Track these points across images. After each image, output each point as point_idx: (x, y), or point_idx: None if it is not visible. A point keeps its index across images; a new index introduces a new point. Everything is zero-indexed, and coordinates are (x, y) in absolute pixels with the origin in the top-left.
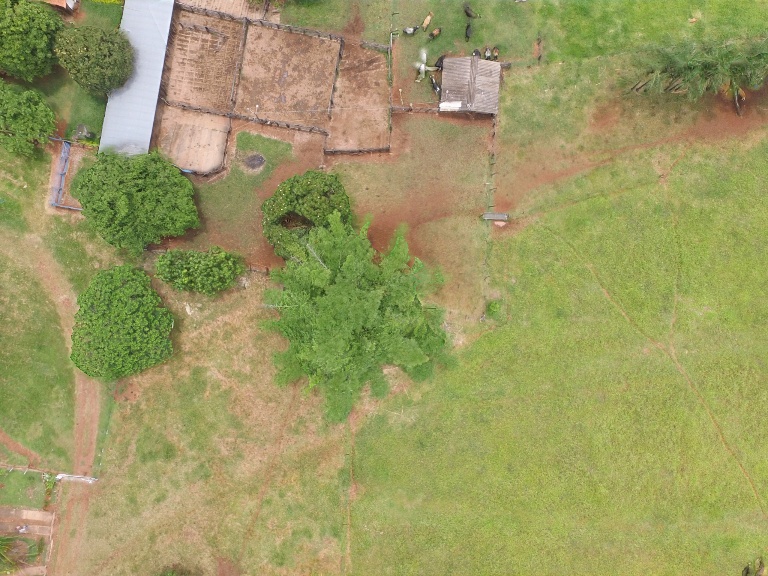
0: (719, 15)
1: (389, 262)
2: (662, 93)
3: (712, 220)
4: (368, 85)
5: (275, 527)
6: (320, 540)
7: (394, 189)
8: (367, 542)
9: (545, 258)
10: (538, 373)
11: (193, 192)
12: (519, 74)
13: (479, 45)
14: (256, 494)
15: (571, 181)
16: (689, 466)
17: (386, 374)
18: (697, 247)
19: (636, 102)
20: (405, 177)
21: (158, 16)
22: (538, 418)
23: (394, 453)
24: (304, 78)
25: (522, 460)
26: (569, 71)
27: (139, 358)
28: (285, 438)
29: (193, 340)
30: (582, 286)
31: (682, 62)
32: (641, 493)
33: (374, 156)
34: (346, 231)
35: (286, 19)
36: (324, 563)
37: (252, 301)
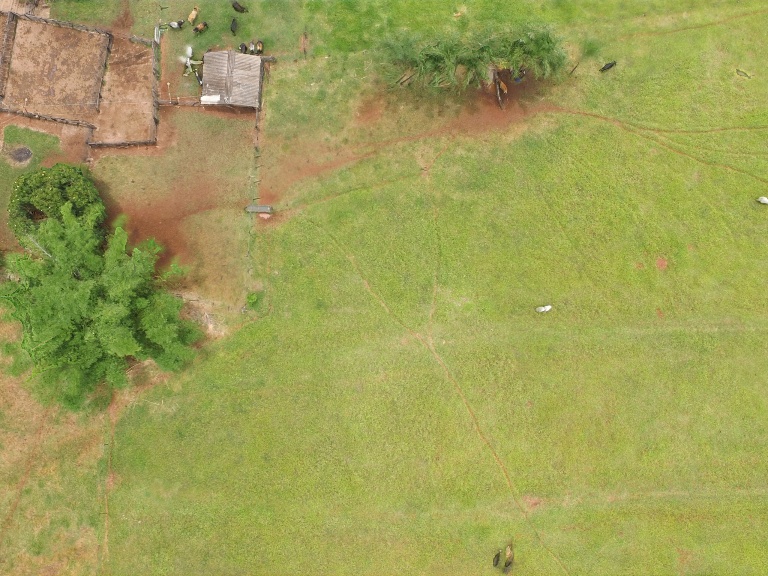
0: (483, 10)
1: (110, 253)
2: (426, 87)
3: (472, 212)
4: (137, 79)
5: (34, 517)
6: (77, 529)
7: (160, 182)
8: (124, 531)
9: (307, 250)
10: (297, 363)
11: None
12: (285, 68)
13: (246, 39)
14: (16, 484)
15: (335, 174)
16: (444, 455)
17: (147, 365)
18: (456, 239)
19: (400, 96)
20: (171, 170)
21: None
22: (296, 408)
23: (153, 443)
24: (73, 72)
25: (279, 449)
26: (335, 65)
27: None
28: (45, 428)
29: None
30: (343, 277)
31: None
32: (395, 482)
33: (141, 149)
34: (80, 222)
35: (56, 13)
36: (82, 552)
37: None
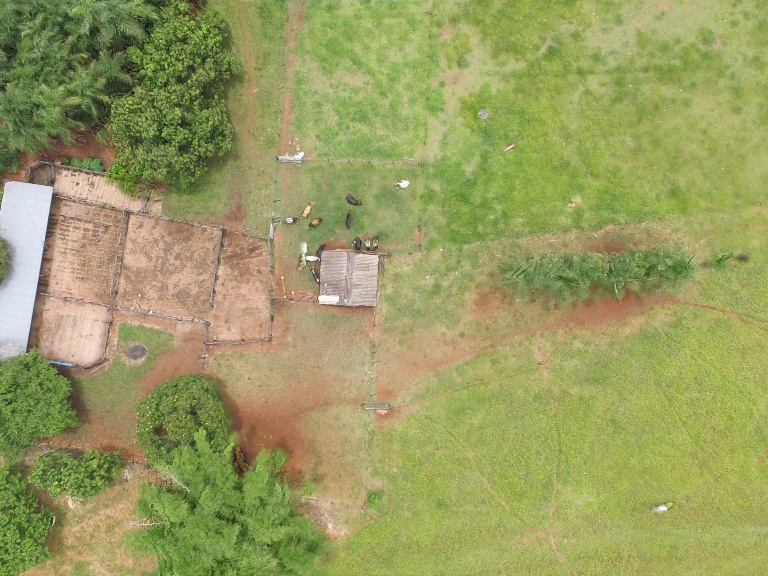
0: (598, 201)
1: (250, 488)
2: (542, 279)
3: (591, 408)
4: (250, 273)
5: None
6: None
7: (276, 378)
8: None
9: (426, 447)
10: (418, 565)
11: (71, 391)
12: (400, 261)
13: (360, 232)
14: None
15: (452, 369)
16: None
17: (268, 567)
18: (576, 436)
19: (516, 288)
20: (287, 366)
21: (35, 212)
22: None
23: None
24: (186, 267)
25: None
26: (450, 257)
27: (14, 564)
28: None
29: (75, 534)
30: (462, 475)
31: (562, 248)
32: None
33: (256, 345)
34: (213, 447)
35: (168, 207)
36: None
37: (134, 494)
